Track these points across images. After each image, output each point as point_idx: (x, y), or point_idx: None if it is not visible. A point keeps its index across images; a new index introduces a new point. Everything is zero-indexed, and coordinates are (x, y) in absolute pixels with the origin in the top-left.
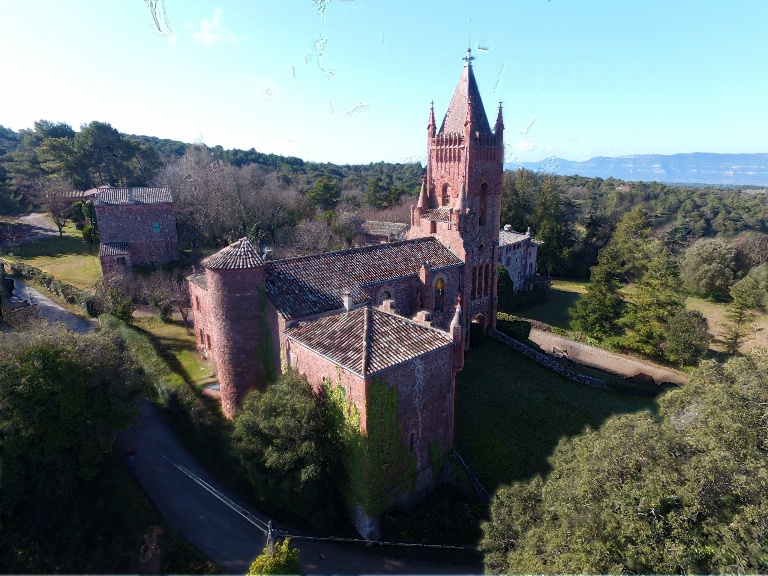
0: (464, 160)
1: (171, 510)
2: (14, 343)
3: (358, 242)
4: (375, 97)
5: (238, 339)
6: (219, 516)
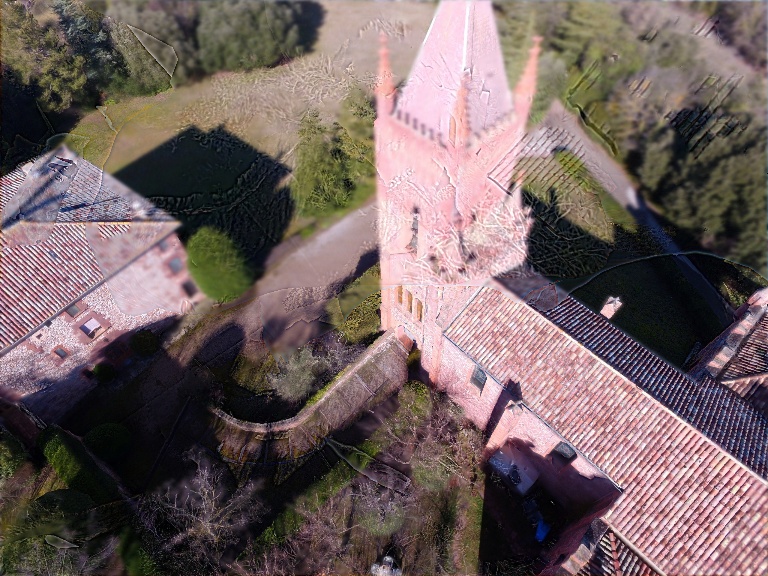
0: None
1: None
2: None
3: None
4: None
5: None
6: None
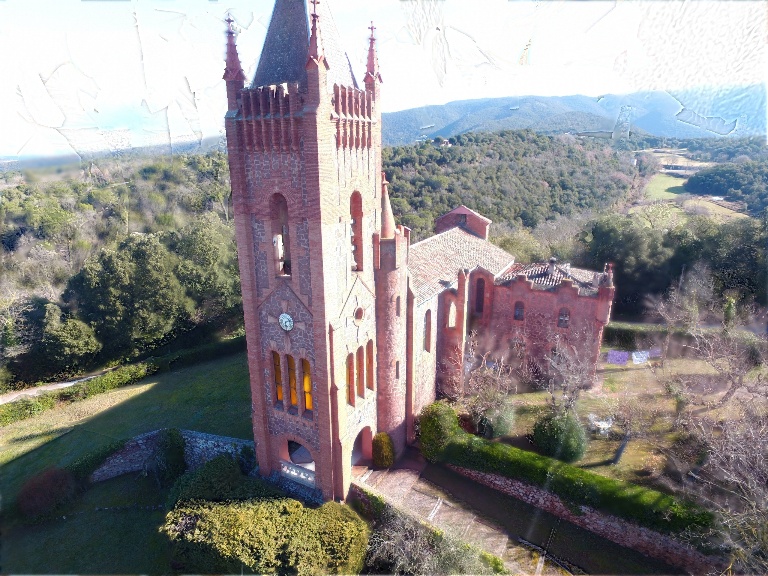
0: None
1: None
2: None
3: None
4: (457, 37)
5: None
6: None
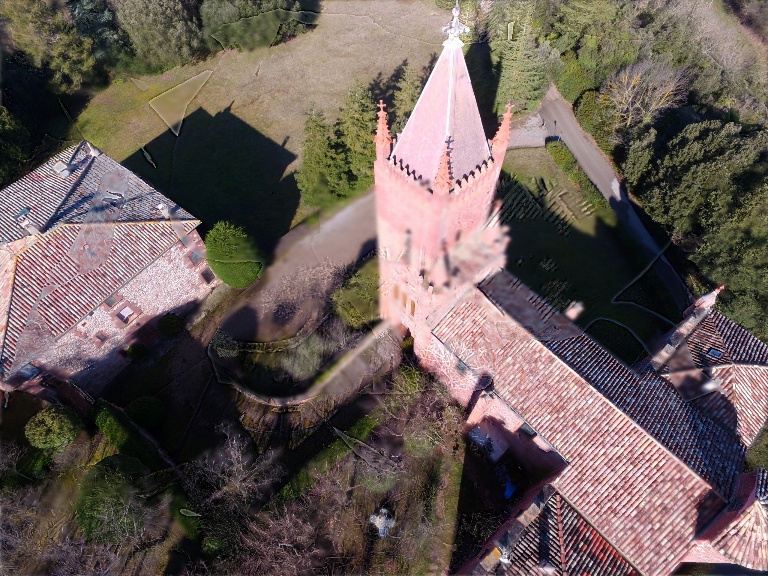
0: None
1: None
2: None
3: (2, 458)
4: None
5: None
6: None
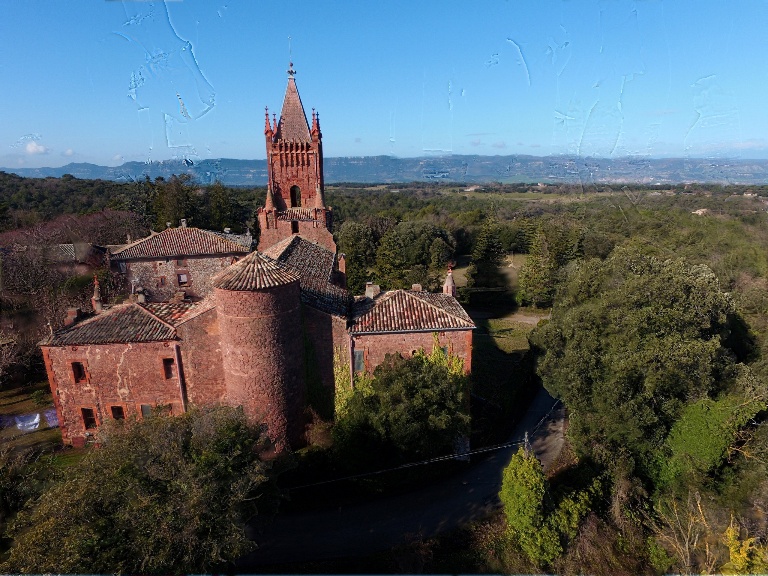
0: (314, 164)
1: (341, 549)
2: (204, 434)
3: None
4: (228, 98)
5: (290, 360)
6: (379, 520)
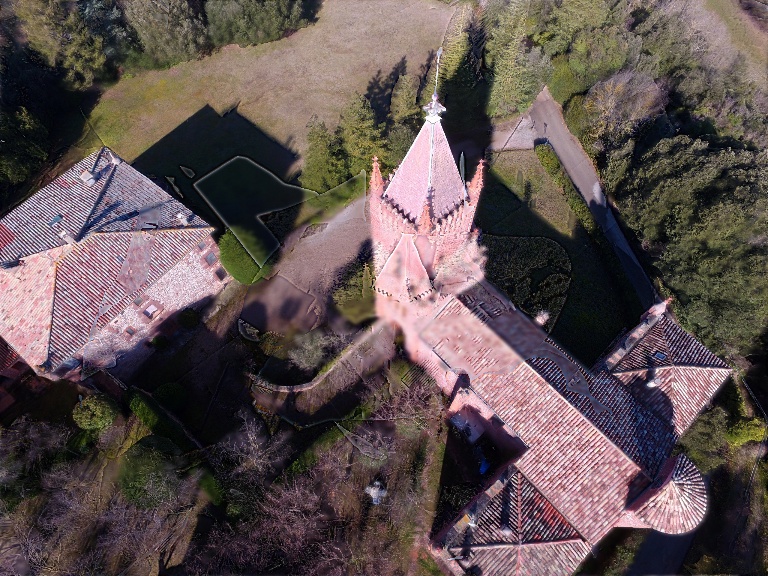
0: None
1: None
2: None
3: (56, 438)
4: None
5: None
6: None
